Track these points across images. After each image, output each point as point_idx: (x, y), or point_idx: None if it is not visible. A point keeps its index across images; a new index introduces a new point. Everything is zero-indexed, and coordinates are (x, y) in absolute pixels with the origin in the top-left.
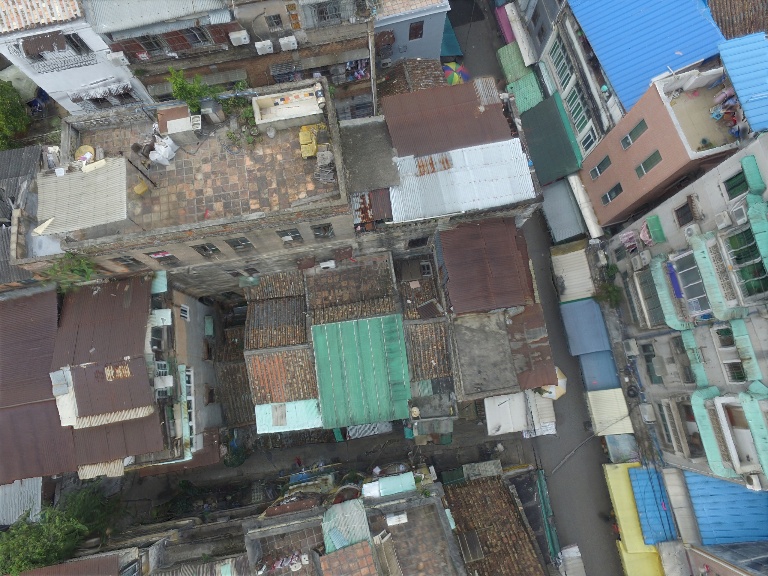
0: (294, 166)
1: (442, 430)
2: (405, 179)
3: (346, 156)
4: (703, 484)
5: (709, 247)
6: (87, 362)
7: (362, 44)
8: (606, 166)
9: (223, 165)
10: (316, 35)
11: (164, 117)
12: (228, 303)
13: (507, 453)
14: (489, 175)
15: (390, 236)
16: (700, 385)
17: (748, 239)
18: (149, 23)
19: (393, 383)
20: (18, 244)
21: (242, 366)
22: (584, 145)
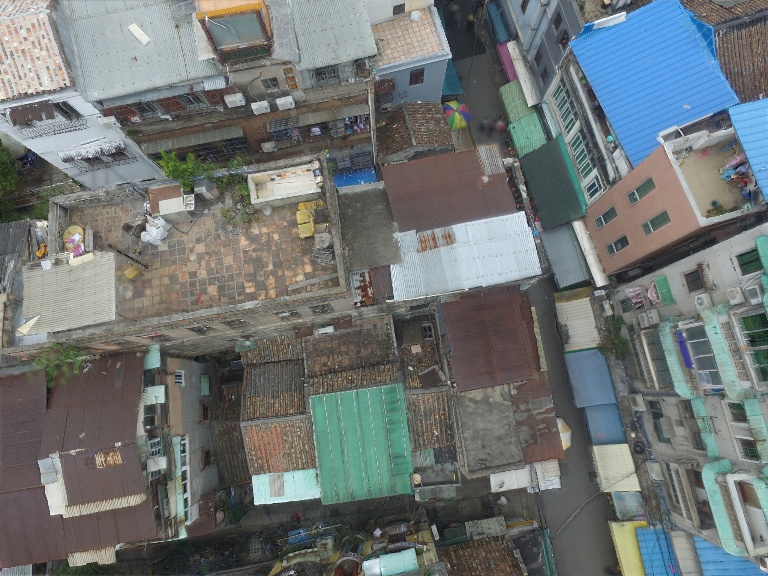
0: (291, 246)
1: (444, 495)
2: (406, 255)
3: (345, 230)
4: (713, 549)
5: (721, 323)
6: (77, 448)
7: (361, 100)
8: (612, 217)
9: (217, 245)
10: (314, 94)
11: (156, 197)
12: (225, 356)
13: (510, 505)
14: (493, 250)
15: (391, 305)
16: (711, 456)
17: (763, 323)
18: (141, 90)
19: (394, 456)
20: (4, 331)
21: (239, 425)
22: (589, 192)
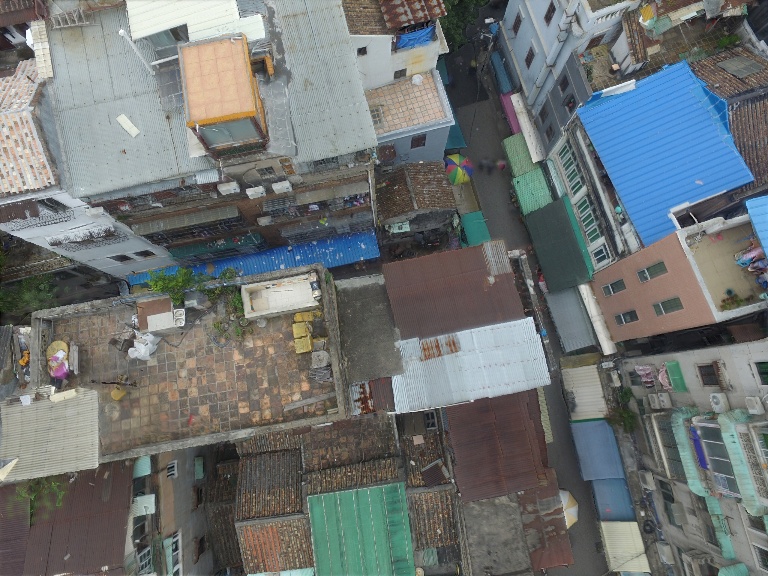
0: (287, 361)
1: None
2: (409, 364)
3: (344, 337)
4: None
5: (739, 432)
6: (61, 573)
7: (361, 178)
8: (620, 289)
9: (209, 360)
10: (312, 176)
11: (144, 311)
12: None
13: None
14: (500, 359)
15: None
16: (726, 557)
17: None
18: (130, 185)
19: (396, 560)
20: None
21: None
22: (596, 257)
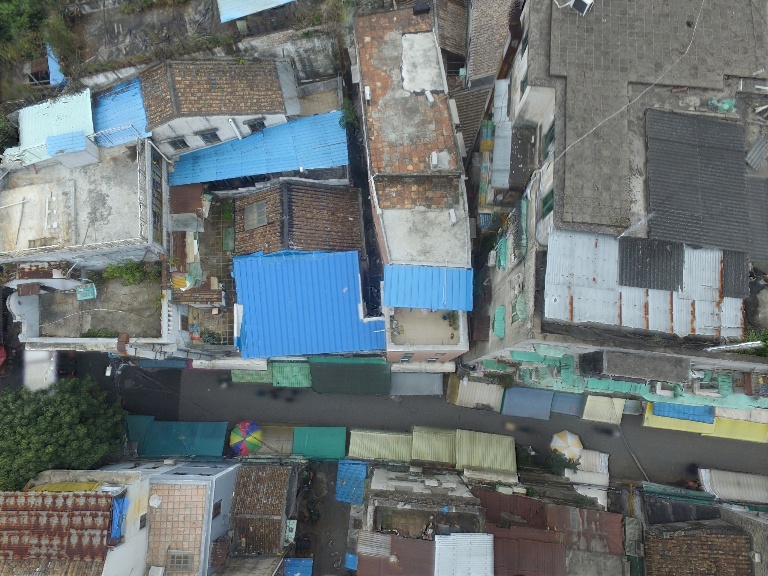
0: None
1: None
2: None
3: None
4: None
5: None
6: None
7: None
8: None
9: None
10: None
11: None
12: None
13: (610, 492)
14: (464, 575)
15: None
16: None
17: None
18: None
19: None
20: None
21: None
22: None
